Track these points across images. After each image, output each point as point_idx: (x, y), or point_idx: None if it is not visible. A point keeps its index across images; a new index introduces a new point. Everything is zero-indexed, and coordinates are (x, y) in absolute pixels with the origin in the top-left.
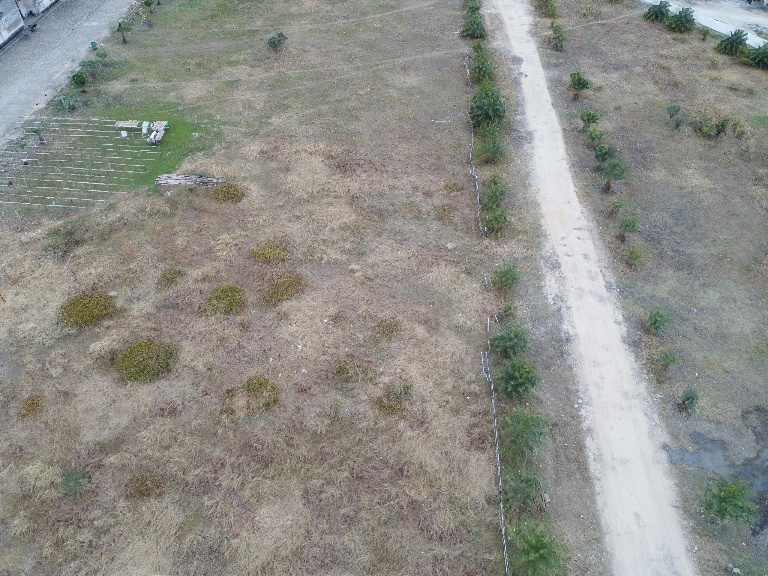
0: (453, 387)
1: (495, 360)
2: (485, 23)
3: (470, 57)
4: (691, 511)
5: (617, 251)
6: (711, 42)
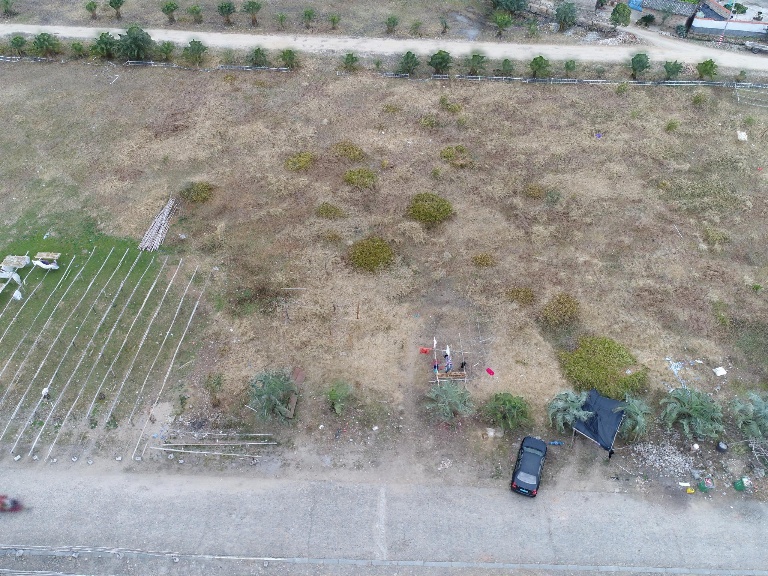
0: None
1: None
2: None
3: None
4: None
5: (322, 30)
6: None
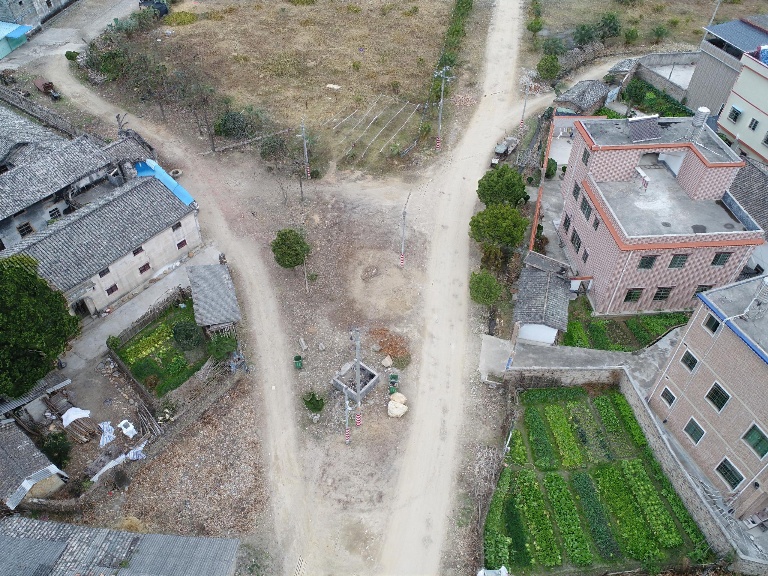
0: (437, 13)
1: None
2: None
3: None
4: (525, 39)
5: None
6: None
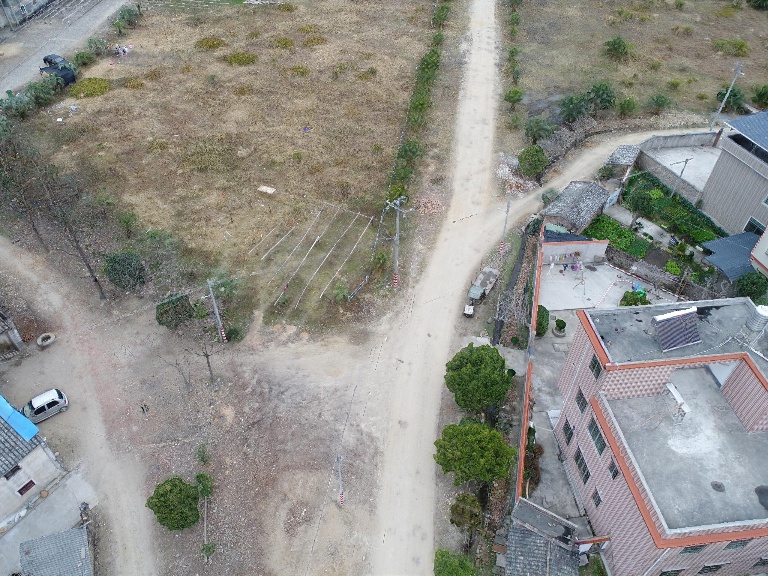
0: (398, 74)
1: None
2: None
3: None
4: (502, 110)
5: (508, 35)
6: None
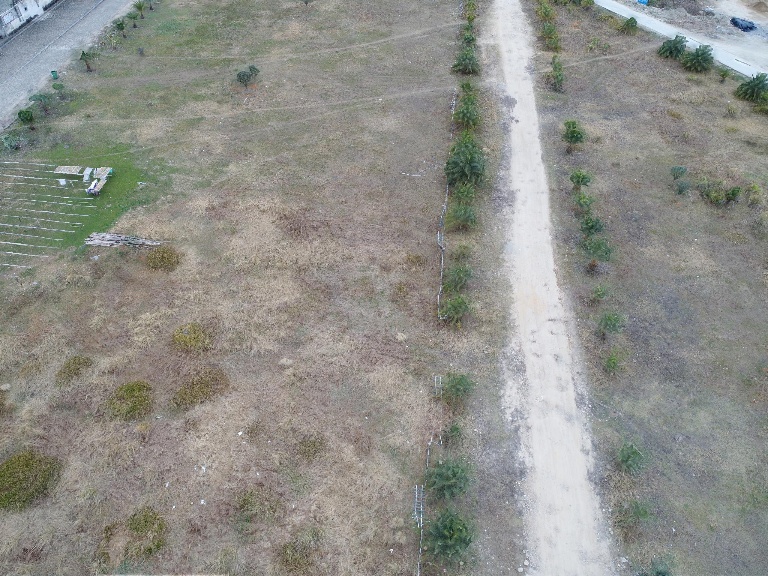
0: (375, 534)
1: (430, 500)
2: (480, 56)
3: (458, 96)
4: None
5: (594, 352)
6: (730, 84)
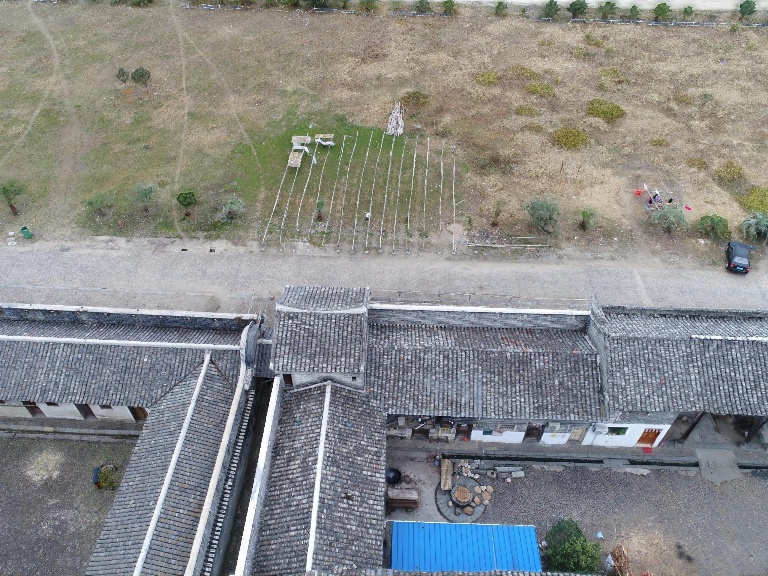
0: None
1: None
2: None
3: None
4: None
5: None
6: None
